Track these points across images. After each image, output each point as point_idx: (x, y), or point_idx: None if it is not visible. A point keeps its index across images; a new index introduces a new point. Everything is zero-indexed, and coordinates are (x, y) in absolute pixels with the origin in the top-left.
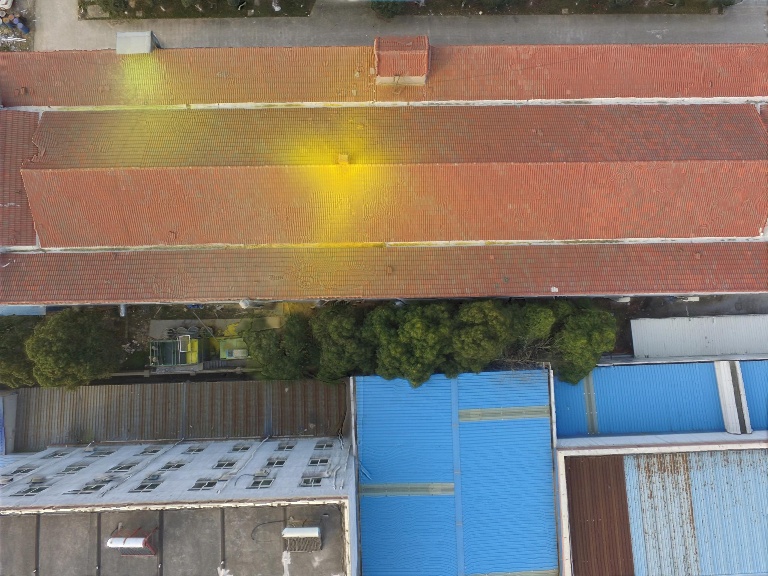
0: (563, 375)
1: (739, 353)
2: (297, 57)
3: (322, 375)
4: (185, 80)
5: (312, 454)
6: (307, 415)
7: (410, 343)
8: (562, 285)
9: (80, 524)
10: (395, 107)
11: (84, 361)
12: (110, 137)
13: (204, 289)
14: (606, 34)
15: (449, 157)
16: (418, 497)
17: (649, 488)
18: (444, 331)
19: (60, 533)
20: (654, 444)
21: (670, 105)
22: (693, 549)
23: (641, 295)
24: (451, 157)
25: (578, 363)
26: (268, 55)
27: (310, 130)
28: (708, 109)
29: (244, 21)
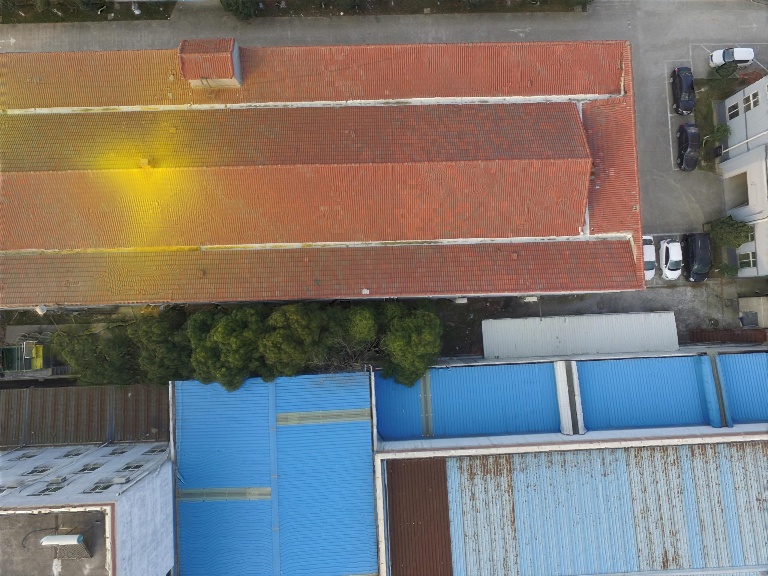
0: (396, 377)
1: (590, 353)
2: (108, 61)
3: (150, 380)
4: None
5: (133, 459)
6: (150, 420)
7: (217, 347)
8: (374, 287)
9: None
10: (212, 110)
11: None
12: None
13: (13, 295)
14: (468, 33)
15: (255, 159)
16: (235, 502)
17: (471, 490)
18: (247, 335)
19: None
20: (478, 446)
21: (490, 104)
22: (513, 551)
23: None
24: (257, 159)
25: (404, 365)
26: (76, 59)
27: (122, 134)
28: (528, 108)
29: (104, 25)
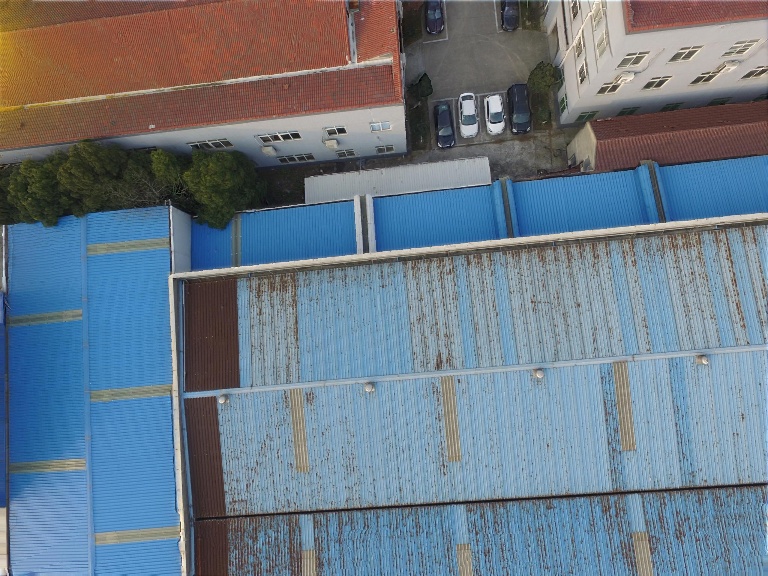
0: None
1: None
2: None
3: None
4: None
5: None
6: None
7: (28, 183)
8: (160, 122)
9: None
10: None
11: None
12: None
13: None
14: None
15: (56, 21)
16: (54, 324)
17: (258, 306)
18: (46, 166)
19: None
20: None
21: None
22: (295, 359)
23: (321, 157)
24: (58, 20)
25: (204, 202)
26: None
27: None
28: None
29: None
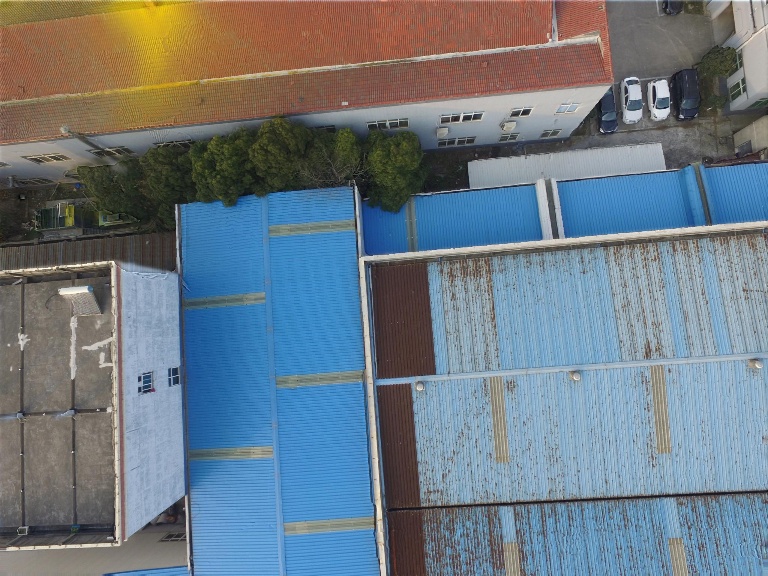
0: (381, 201)
1: None
2: None
3: (161, 213)
4: None
5: None
6: (164, 263)
7: (214, 160)
8: (352, 99)
9: None
10: None
11: None
12: None
13: (43, 130)
14: None
15: None
16: (234, 307)
17: (452, 291)
18: (238, 142)
19: None
20: None
21: None
22: (494, 346)
23: (481, 141)
24: None
25: (387, 183)
26: None
27: None
28: None
29: None
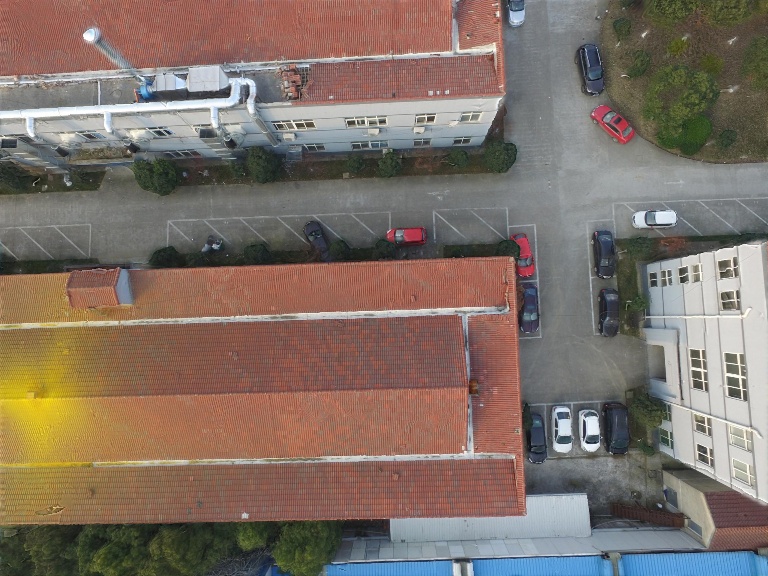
0: None
1: (499, 538)
2: (6, 286)
3: None
4: None
5: None
6: None
7: None
8: (254, 511)
9: None
10: (106, 327)
11: None
12: None
13: None
14: (386, 197)
15: (138, 388)
16: None
17: None
18: (125, 565)
19: None
20: None
21: (375, 319)
22: None
23: None
24: (140, 388)
25: (294, 574)
26: None
27: (18, 356)
28: (412, 323)
29: (38, 197)
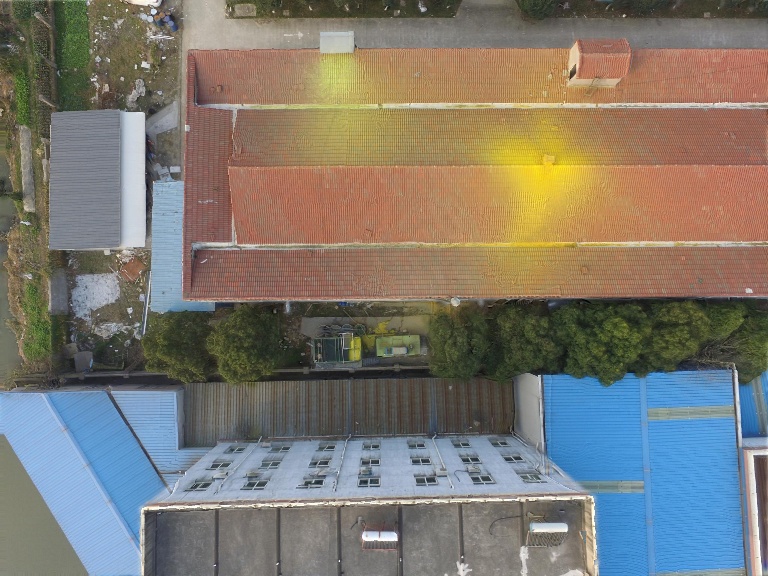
0: None
1: None
2: (494, 58)
3: (501, 373)
4: (383, 80)
5: (499, 451)
6: (471, 413)
7: (609, 342)
8: (756, 286)
9: (320, 518)
10: (584, 109)
11: (270, 357)
12: (304, 135)
13: (404, 287)
14: (748, 38)
15: (649, 159)
16: (607, 494)
17: None
18: (648, 331)
19: (300, 526)
20: None
21: None
22: None
23: None
24: (651, 159)
25: (757, 363)
26: (467, 56)
27: (506, 131)
28: None
29: (390, 21)
